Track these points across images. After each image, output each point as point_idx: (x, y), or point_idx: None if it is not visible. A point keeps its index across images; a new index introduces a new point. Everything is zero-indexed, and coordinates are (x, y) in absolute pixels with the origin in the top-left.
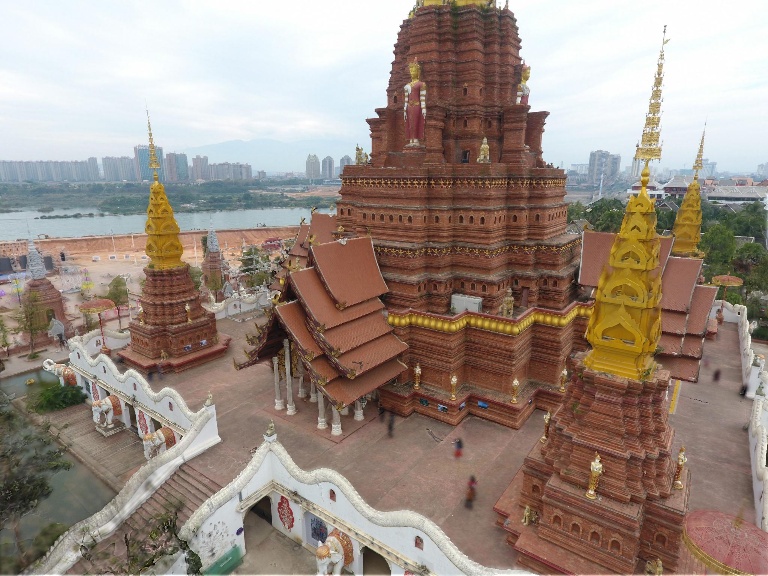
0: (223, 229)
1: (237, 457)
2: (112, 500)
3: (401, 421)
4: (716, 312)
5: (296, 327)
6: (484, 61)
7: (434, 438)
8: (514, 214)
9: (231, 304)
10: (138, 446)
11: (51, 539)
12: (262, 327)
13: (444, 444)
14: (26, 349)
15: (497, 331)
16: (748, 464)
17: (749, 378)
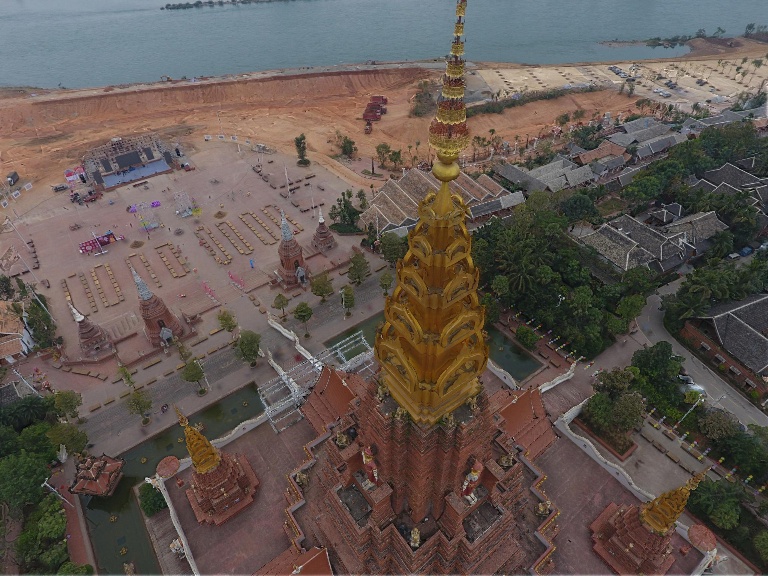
0: (330, 69)
1: None
2: None
3: None
4: None
5: None
6: (435, 456)
7: None
8: None
9: None
10: None
11: None
12: None
13: None
14: (148, 356)
15: None
16: None
17: None
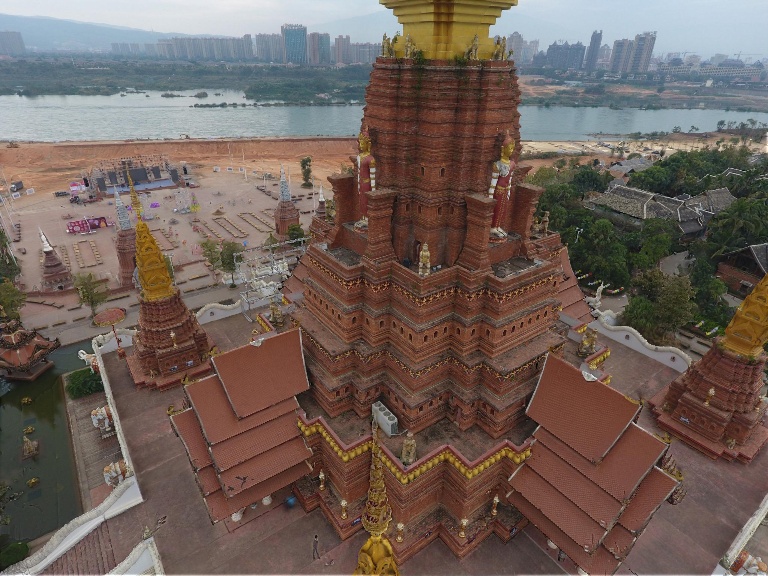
0: (339, 136)
1: None
2: (40, 549)
3: (300, 516)
4: None
5: (190, 435)
6: (453, 131)
7: (314, 552)
8: (458, 327)
9: (248, 300)
10: (118, 457)
11: (9, 558)
12: (186, 407)
13: (317, 564)
14: (115, 292)
15: (390, 471)
16: None
17: (712, 573)
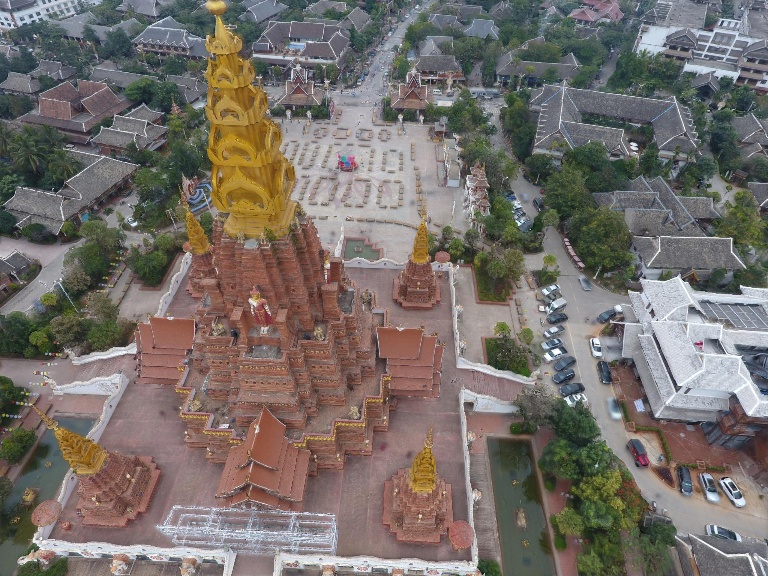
0: None
1: (460, 383)
2: None
3: None
4: (186, 264)
5: None
6: None
7: None
8: None
9: None
10: None
11: None
12: None
13: None
14: None
15: None
16: (360, 268)
17: None
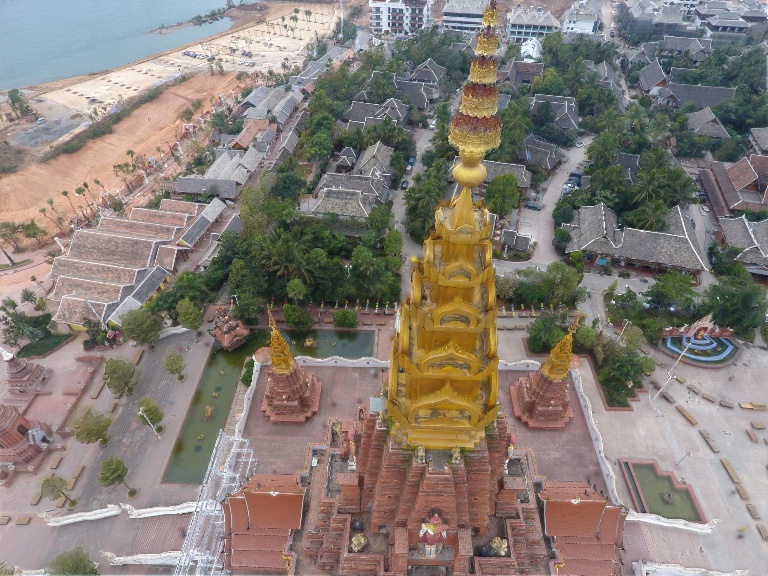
0: None
1: None
2: None
3: None
4: None
5: None
6: None
7: None
8: (514, 543)
9: None
10: None
11: None
12: None
13: None
14: None
15: None
16: None
17: None
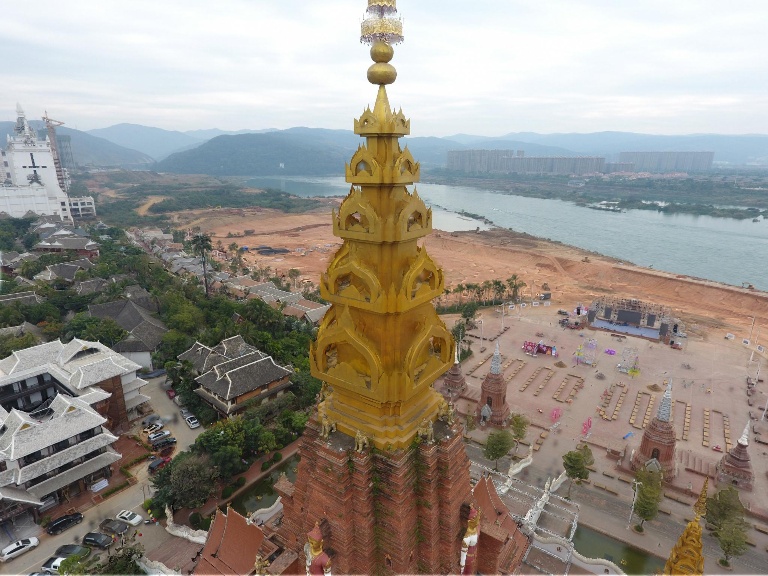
0: None
1: None
2: None
3: None
4: None
5: None
6: None
7: None
8: None
9: None
10: None
11: (203, 523)
12: None
13: None
14: (460, 415)
15: None
16: None
17: None
